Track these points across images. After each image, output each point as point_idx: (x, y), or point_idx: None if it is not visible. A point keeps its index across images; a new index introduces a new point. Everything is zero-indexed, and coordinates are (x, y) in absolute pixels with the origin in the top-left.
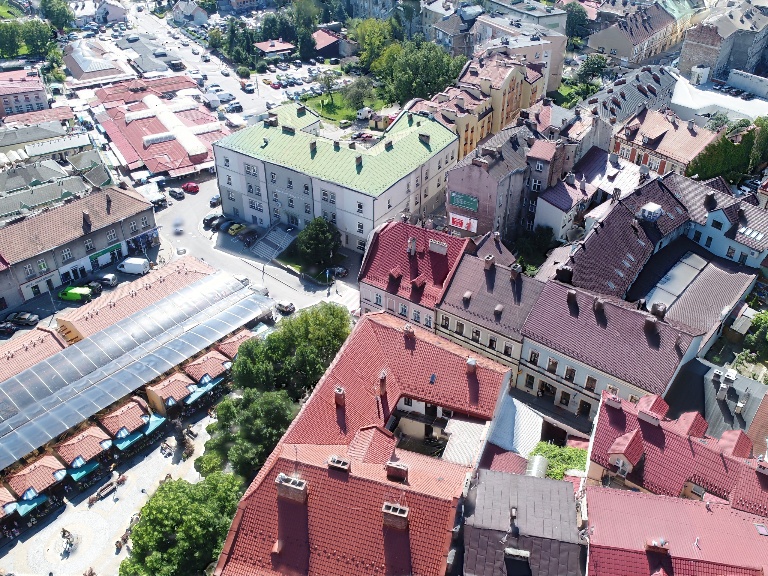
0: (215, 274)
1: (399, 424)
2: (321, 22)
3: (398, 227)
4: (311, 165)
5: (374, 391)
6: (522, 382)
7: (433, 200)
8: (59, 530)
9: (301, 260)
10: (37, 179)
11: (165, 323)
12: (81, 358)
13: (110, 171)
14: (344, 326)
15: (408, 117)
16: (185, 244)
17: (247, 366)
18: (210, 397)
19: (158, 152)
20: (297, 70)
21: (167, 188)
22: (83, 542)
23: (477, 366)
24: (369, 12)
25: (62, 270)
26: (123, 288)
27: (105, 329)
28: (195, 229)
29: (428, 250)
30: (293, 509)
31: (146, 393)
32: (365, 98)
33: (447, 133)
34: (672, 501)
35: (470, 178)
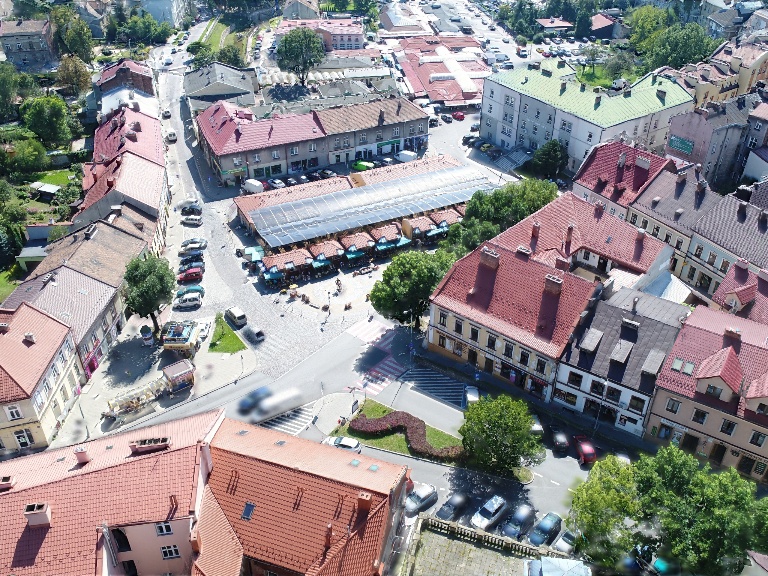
0: (465, 166)
1: (576, 270)
2: (603, 8)
3: (615, 145)
4: (558, 100)
5: (562, 237)
6: (685, 273)
7: (658, 150)
8: (334, 283)
9: (532, 173)
10: (349, 92)
11: (423, 188)
12: (364, 195)
13: (402, 94)
14: (552, 198)
15: (653, 78)
16: (446, 151)
17: (476, 205)
18: (443, 238)
19: (439, 87)
20: (569, 45)
21: (440, 114)
22: (347, 292)
23: (646, 236)
24: (650, 2)
25: (358, 149)
26: (398, 164)
27: (382, 182)
28: (455, 143)
29: (634, 165)
30: (488, 272)
31: (402, 223)
32: (623, 70)
33: (684, 94)
34: (762, 325)
35: (690, 124)
